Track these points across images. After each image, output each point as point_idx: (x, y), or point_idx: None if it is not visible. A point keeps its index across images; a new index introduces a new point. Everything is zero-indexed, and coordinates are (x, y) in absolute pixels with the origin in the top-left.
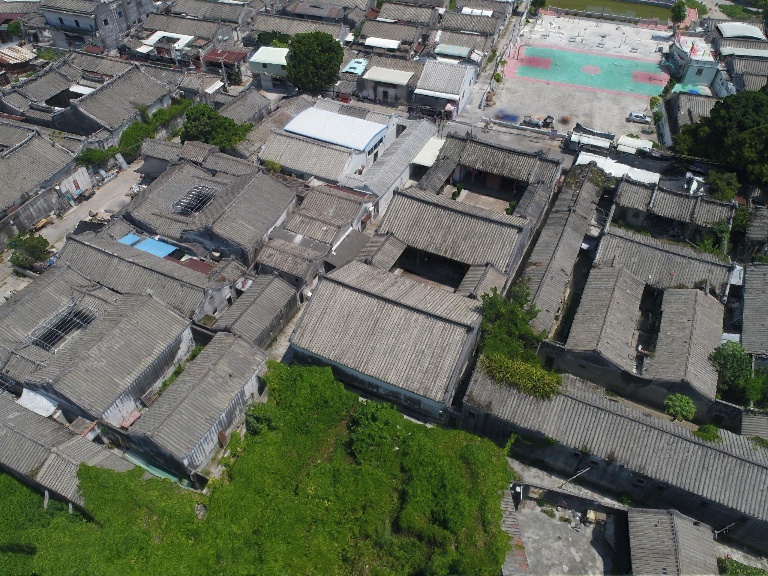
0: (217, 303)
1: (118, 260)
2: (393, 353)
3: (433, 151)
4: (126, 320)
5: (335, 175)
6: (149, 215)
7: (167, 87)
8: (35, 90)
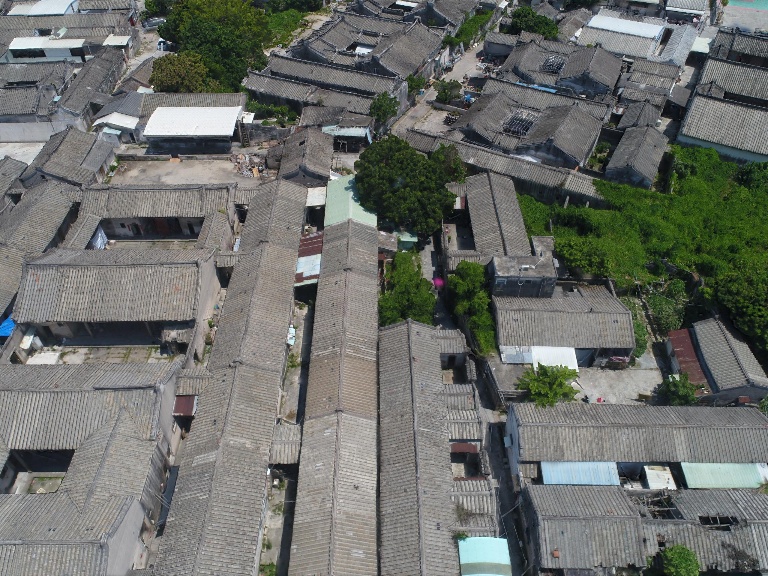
0: (607, 118)
1: (532, 91)
2: (761, 137)
3: (703, 44)
4: (570, 116)
5: (643, 54)
6: (527, 71)
7: (476, 1)
8: (378, 0)
